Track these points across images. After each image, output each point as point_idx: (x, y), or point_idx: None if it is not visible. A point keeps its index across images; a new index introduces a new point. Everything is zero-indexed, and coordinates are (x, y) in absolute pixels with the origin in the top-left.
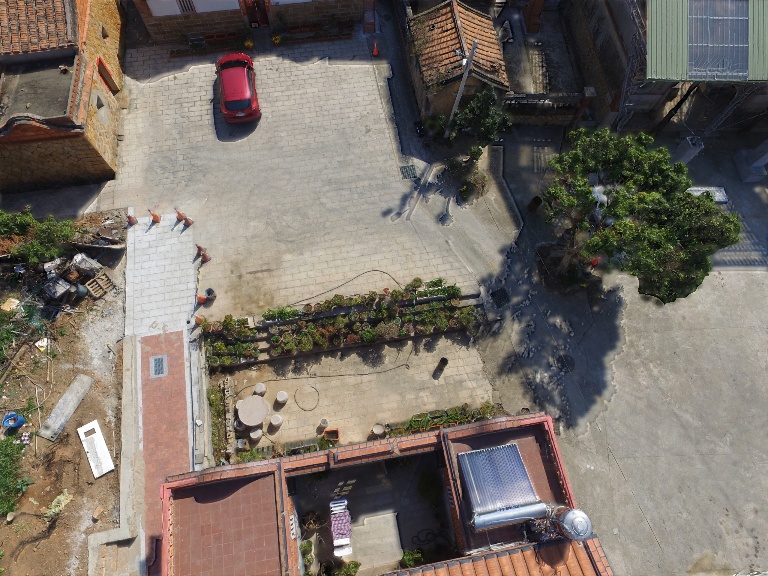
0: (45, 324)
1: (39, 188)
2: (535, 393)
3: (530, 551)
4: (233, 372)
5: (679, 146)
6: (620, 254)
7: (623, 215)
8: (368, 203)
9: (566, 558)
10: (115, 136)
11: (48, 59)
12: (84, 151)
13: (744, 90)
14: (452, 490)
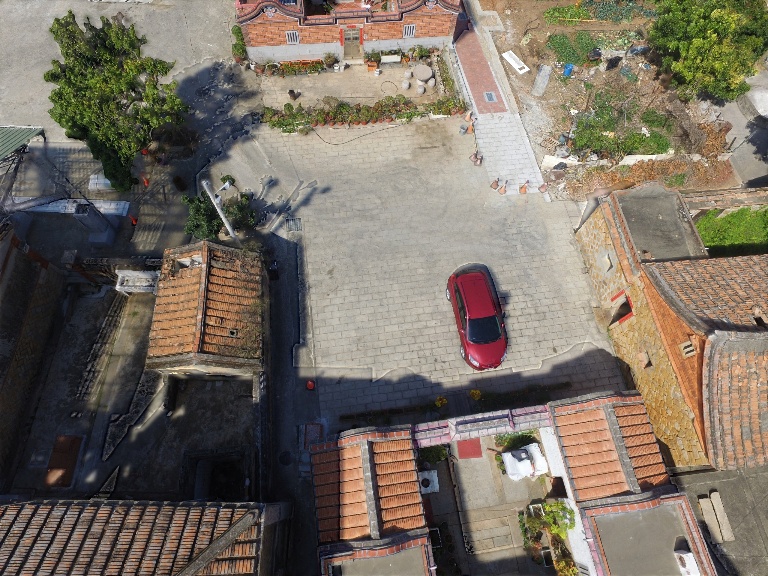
0: None
1: None
2: (231, 78)
3: None
4: None
5: None
6: None
7: None
8: (337, 197)
9: None
10: None
11: None
12: None
13: None
14: None
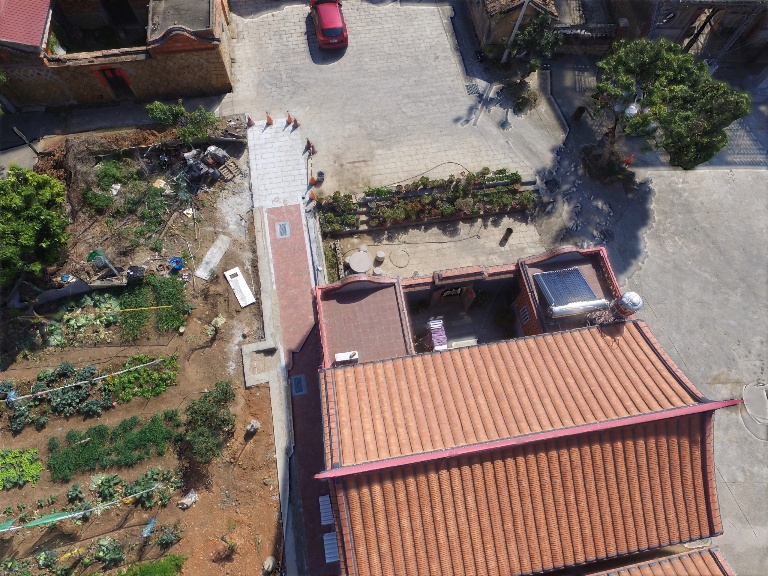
0: (191, 196)
1: (170, 99)
2: None
3: (595, 329)
4: (339, 239)
5: None
6: (655, 132)
7: (658, 102)
8: (441, 112)
9: (622, 332)
10: (230, 58)
11: None
12: (214, 64)
13: (752, 11)
14: (530, 299)
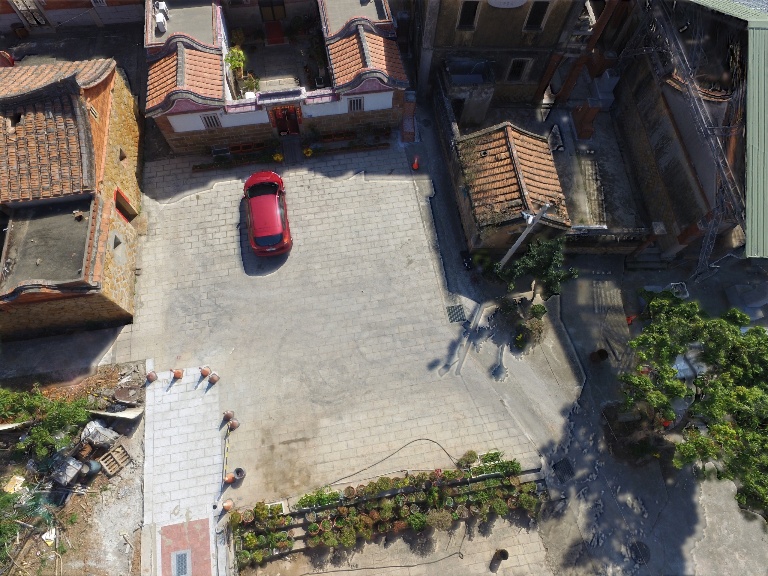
0: (53, 513)
1: (48, 333)
2: None
3: None
4: (264, 563)
5: (757, 288)
6: (717, 462)
7: (720, 416)
8: (413, 353)
9: None
10: (133, 271)
11: (61, 202)
12: (99, 303)
13: None
14: None
